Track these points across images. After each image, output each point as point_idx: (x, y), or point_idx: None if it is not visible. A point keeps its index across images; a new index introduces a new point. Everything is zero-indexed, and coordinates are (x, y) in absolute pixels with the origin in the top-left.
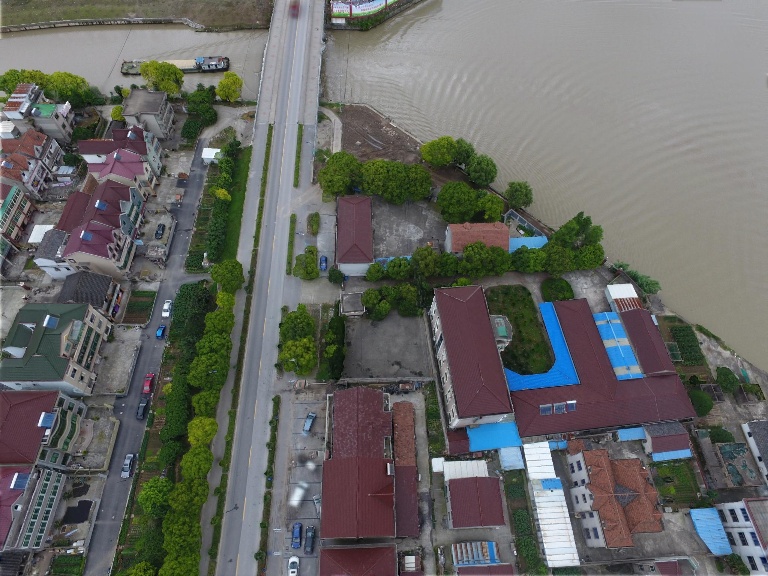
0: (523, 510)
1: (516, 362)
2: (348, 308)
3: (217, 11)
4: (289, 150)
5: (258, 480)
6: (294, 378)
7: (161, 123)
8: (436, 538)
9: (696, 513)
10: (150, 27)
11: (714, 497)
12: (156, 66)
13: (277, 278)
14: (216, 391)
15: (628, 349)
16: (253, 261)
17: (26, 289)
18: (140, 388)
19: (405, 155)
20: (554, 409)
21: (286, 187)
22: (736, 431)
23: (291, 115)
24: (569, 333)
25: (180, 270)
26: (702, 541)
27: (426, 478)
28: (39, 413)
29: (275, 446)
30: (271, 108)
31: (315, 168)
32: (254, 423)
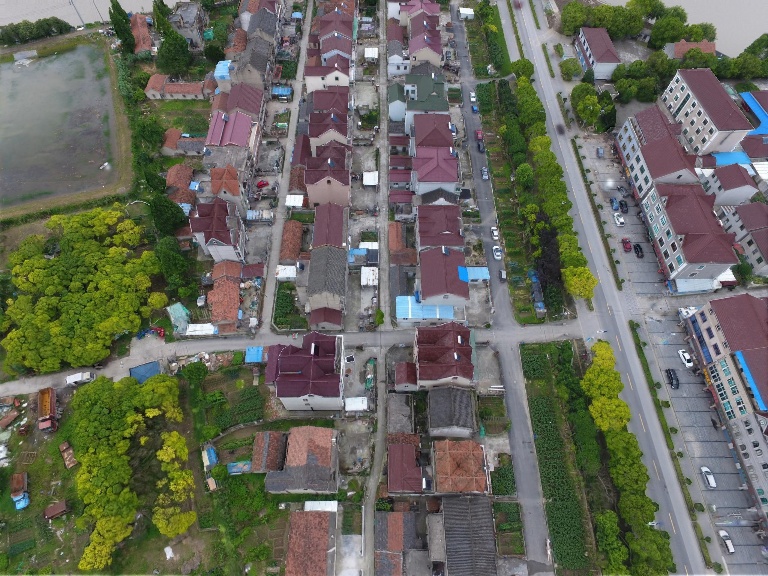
0: (759, 197)
1: None
2: None
3: None
4: (525, 7)
5: (577, 179)
6: (579, 131)
7: None
8: None
9: None
10: None
11: None
12: None
13: (545, 79)
14: None
15: None
16: None
17: (373, 84)
18: (473, 137)
19: None
20: None
21: (531, 29)
22: None
23: None
24: (767, 106)
25: (471, 78)
26: None
27: None
28: (446, 123)
29: (582, 163)
30: None
31: (547, 19)
32: (562, 152)
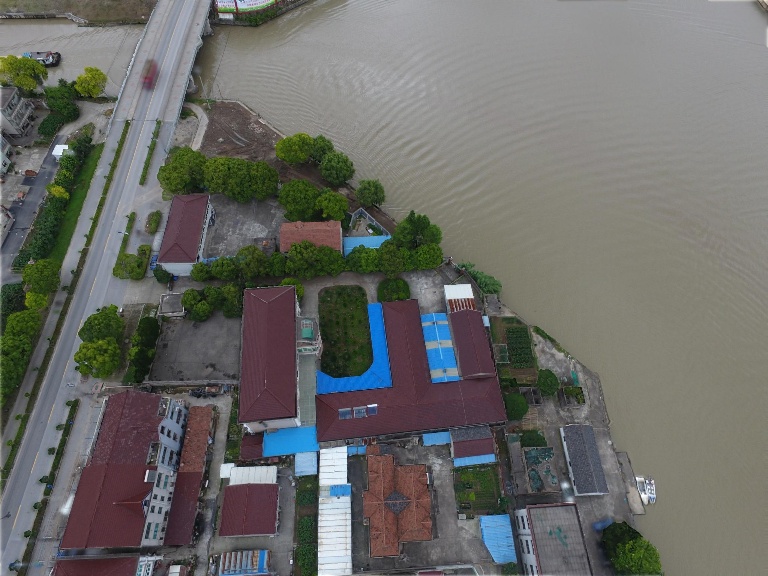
0: (309, 517)
1: (334, 364)
2: (166, 309)
3: (102, 6)
4: (142, 147)
5: (38, 487)
6: (99, 381)
7: (11, 119)
8: (213, 546)
9: (486, 520)
10: (33, 22)
11: (515, 503)
12: (10, 61)
13: (103, 278)
14: (0, 395)
15: (449, 351)
16: (80, 260)
17: None
18: None
19: (267, 152)
20: (354, 413)
21: (132, 185)
22: (554, 435)
23: (152, 111)
24: (391, 335)
25: (7, 270)
26: (487, 549)
27: (216, 484)
28: None
29: (63, 451)
30: (132, 104)
31: None
32: (46, 427)
